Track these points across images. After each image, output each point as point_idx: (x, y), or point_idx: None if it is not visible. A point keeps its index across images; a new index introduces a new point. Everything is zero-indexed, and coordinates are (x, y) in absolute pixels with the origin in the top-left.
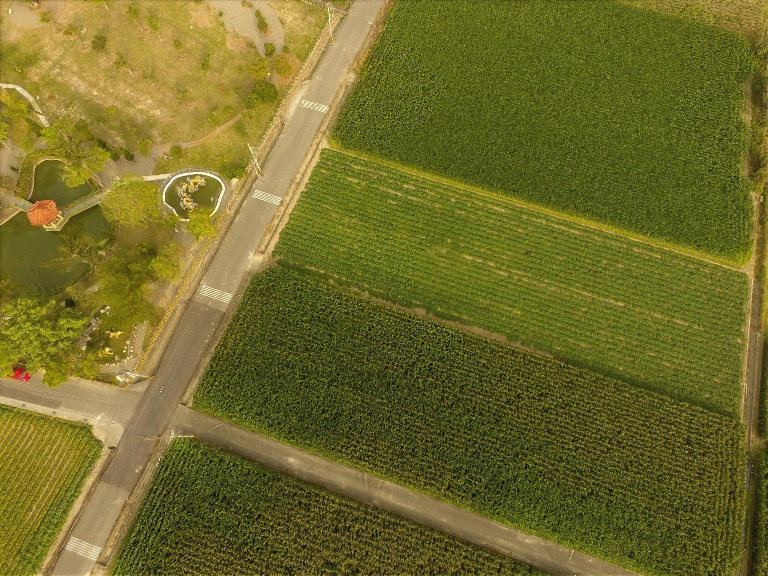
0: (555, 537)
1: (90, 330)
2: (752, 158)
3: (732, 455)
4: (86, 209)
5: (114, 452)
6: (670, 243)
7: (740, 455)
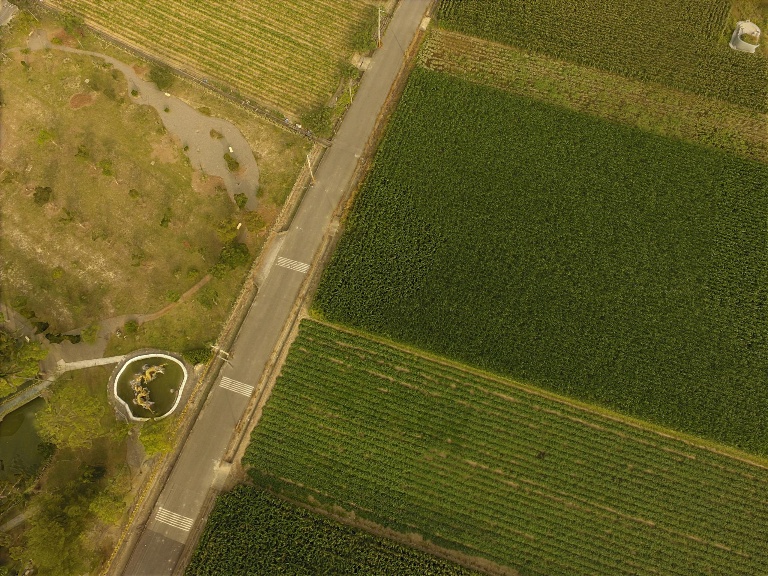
0: None
1: (22, 575)
2: None
3: None
4: (24, 404)
5: None
6: (706, 440)
7: None
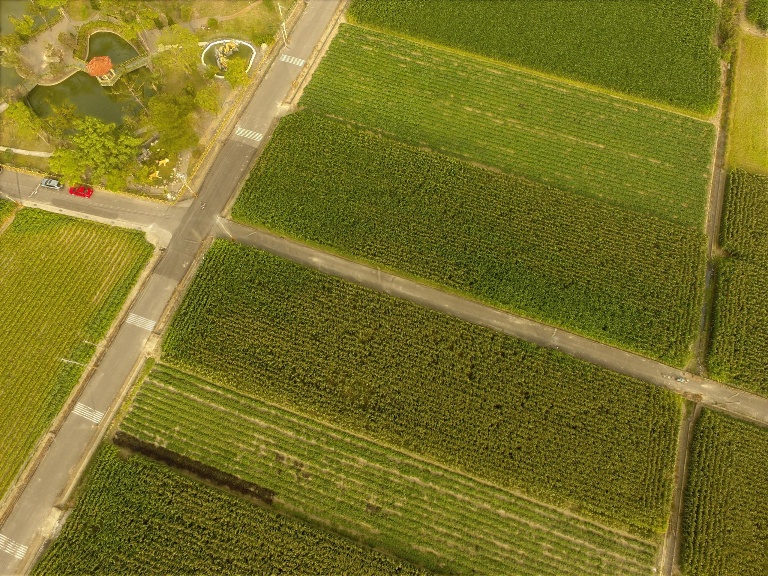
0: (540, 315)
1: (142, 159)
2: (721, 32)
3: (694, 256)
4: (135, 69)
5: (164, 252)
6: (646, 99)
7: (701, 256)
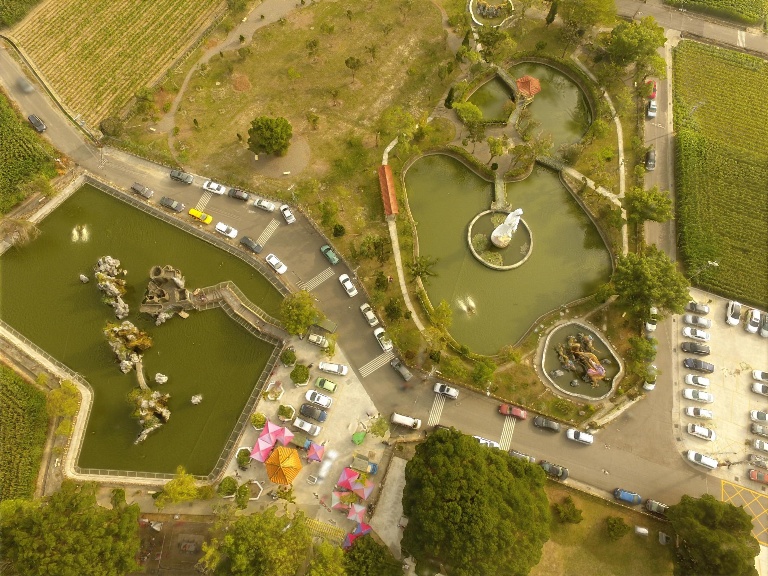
0: None
1: None
2: None
3: None
4: None
5: (684, 32)
6: None
7: None
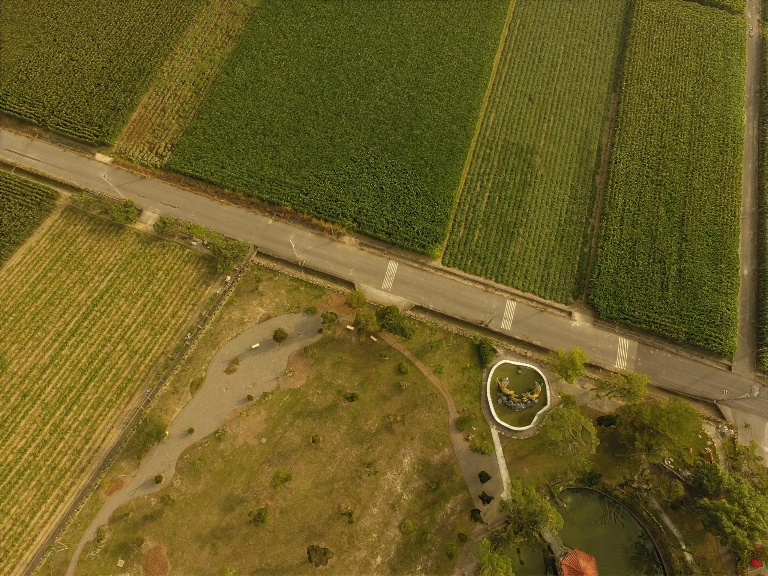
0: None
1: None
2: None
3: (661, 2)
4: None
5: None
6: None
7: None
